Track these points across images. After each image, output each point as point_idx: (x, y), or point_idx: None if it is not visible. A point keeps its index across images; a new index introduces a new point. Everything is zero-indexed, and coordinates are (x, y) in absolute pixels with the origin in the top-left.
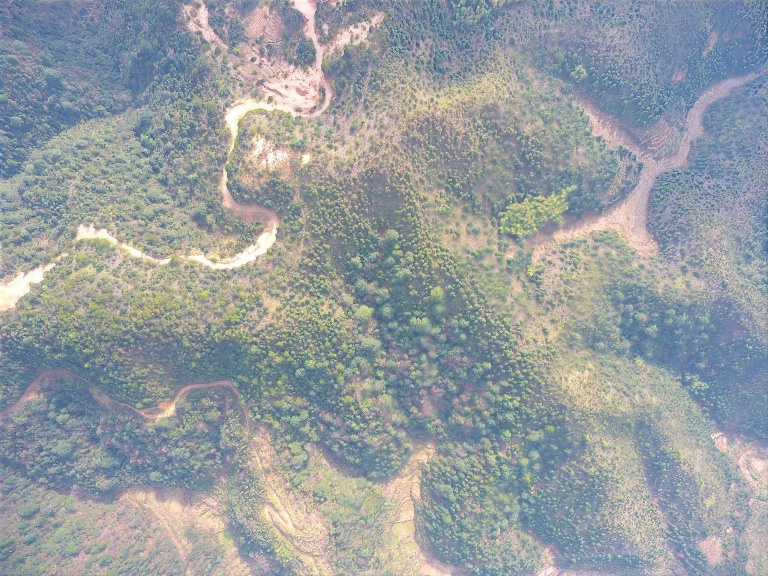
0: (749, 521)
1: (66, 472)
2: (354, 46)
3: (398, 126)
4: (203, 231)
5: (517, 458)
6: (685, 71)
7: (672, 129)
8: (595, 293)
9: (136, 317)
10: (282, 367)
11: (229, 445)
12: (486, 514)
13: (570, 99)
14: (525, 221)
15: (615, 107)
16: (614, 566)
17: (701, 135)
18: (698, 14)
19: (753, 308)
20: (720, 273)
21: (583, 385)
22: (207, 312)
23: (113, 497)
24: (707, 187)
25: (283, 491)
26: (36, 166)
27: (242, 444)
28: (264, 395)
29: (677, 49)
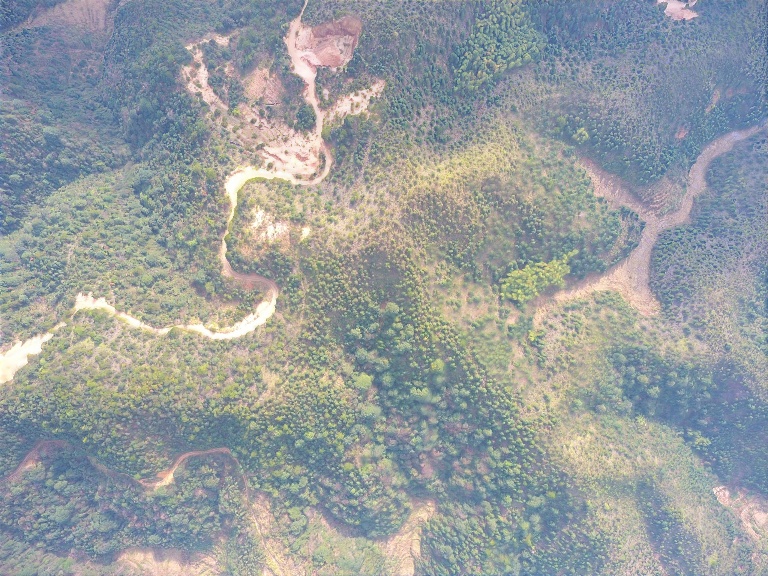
0: (751, 575)
1: (64, 537)
2: (354, 116)
3: (398, 203)
4: (202, 298)
5: (518, 522)
6: (688, 128)
7: (674, 186)
8: (597, 358)
9: (134, 393)
10: (281, 438)
11: (228, 510)
12: None
13: (572, 162)
14: (526, 287)
15: (617, 167)
16: None
17: (704, 191)
18: (701, 74)
19: (756, 369)
20: (723, 336)
21: (584, 451)
22: (206, 387)
23: (111, 558)
24: (710, 246)
25: (282, 557)
26: (35, 227)
27: (241, 510)
28: (263, 466)
29: (680, 108)
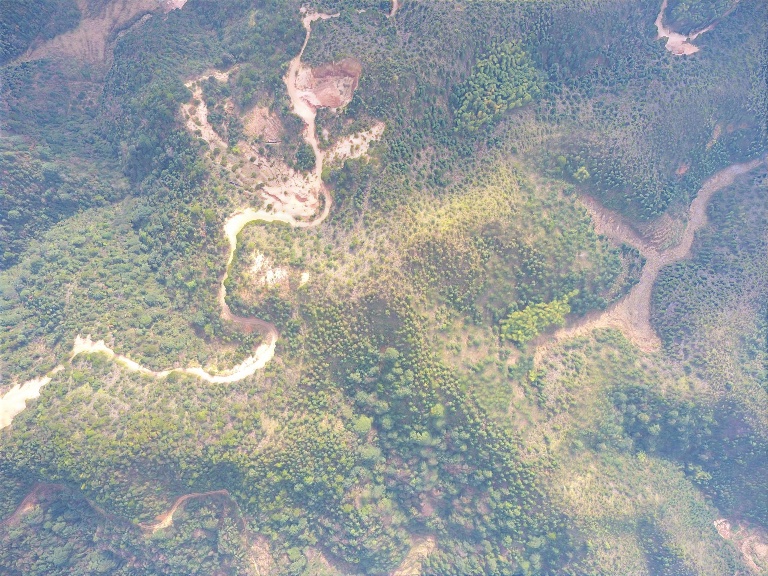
0: None
1: None
2: (354, 160)
3: (398, 251)
4: (201, 340)
5: (518, 561)
6: (689, 164)
7: (675, 222)
8: (597, 398)
9: (133, 441)
10: (280, 482)
11: (227, 551)
12: None
13: (572, 201)
14: (527, 328)
15: (618, 203)
16: None
17: (705, 225)
18: (702, 111)
19: (757, 407)
20: (724, 375)
21: (585, 492)
22: (205, 433)
23: None
24: (711, 283)
25: None
26: (33, 265)
27: (240, 552)
28: (262, 511)
29: (681, 145)
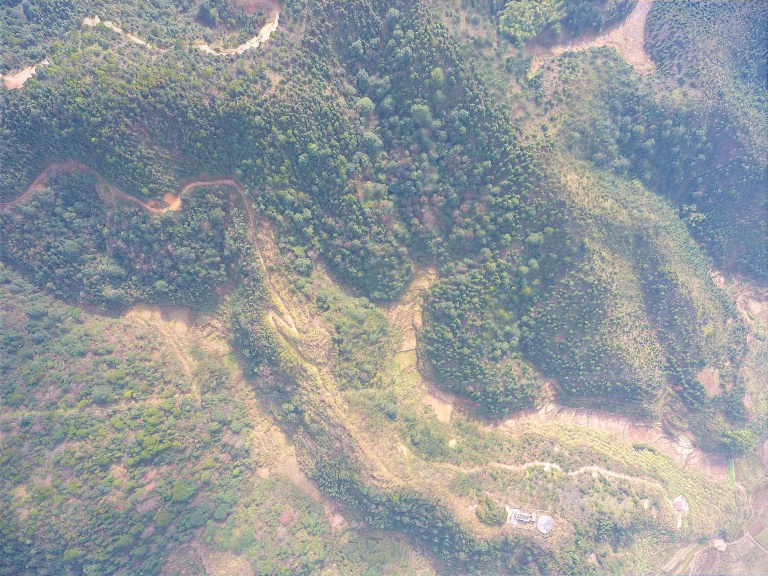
0: (746, 357)
1: (73, 276)
2: None
3: None
4: (206, 27)
5: (517, 266)
6: None
7: None
8: (593, 97)
9: (142, 87)
10: (285, 152)
11: (233, 248)
12: (487, 326)
13: None
14: (524, 21)
15: None
16: (613, 401)
17: None
18: None
19: (749, 122)
20: (716, 82)
21: (582, 186)
22: None
23: (119, 313)
24: (703, 6)
25: (287, 293)
26: None
27: (246, 244)
28: (268, 180)
29: None
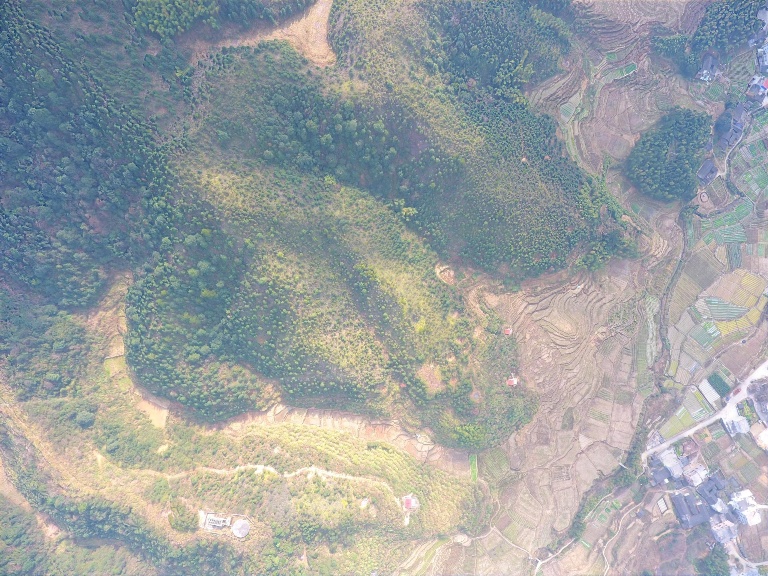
0: (476, 352)
1: None
2: None
3: None
4: None
5: (185, 269)
6: None
7: None
8: (246, 93)
9: None
10: None
11: None
12: (165, 330)
13: None
14: (162, 17)
15: None
16: (340, 400)
17: None
18: None
19: (428, 114)
20: (383, 74)
21: (235, 186)
22: None
23: None
24: None
25: None
26: None
27: None
28: None
29: None
